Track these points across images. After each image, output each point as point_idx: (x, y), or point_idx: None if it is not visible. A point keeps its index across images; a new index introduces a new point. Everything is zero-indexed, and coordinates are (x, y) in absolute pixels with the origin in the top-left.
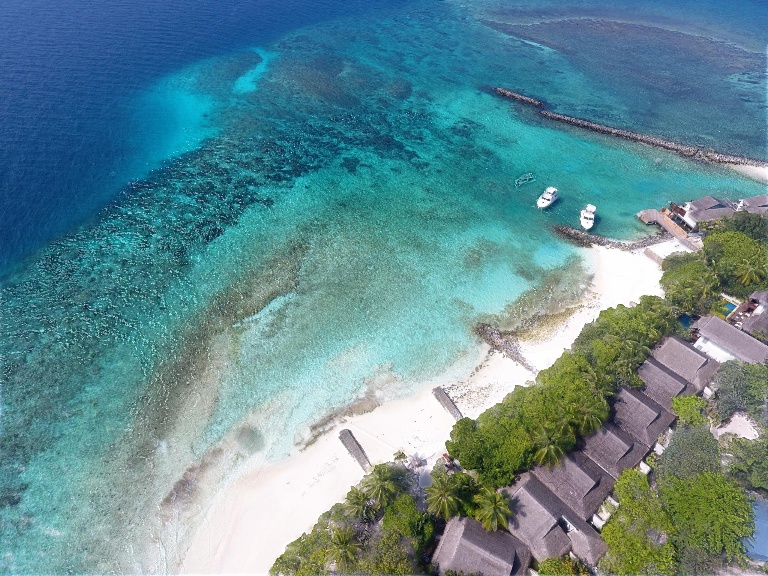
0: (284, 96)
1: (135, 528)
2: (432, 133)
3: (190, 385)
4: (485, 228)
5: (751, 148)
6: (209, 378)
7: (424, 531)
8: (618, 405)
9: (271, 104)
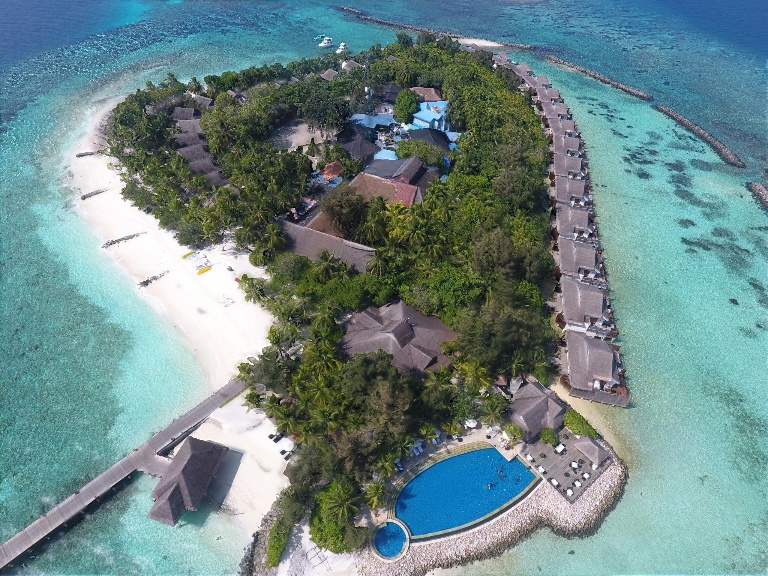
0: (198, 5)
1: (80, 106)
2: (283, 22)
3: (110, 83)
4: (284, 53)
5: (475, 34)
6: (119, 82)
7: (186, 95)
8: (289, 82)
9: (188, 8)
